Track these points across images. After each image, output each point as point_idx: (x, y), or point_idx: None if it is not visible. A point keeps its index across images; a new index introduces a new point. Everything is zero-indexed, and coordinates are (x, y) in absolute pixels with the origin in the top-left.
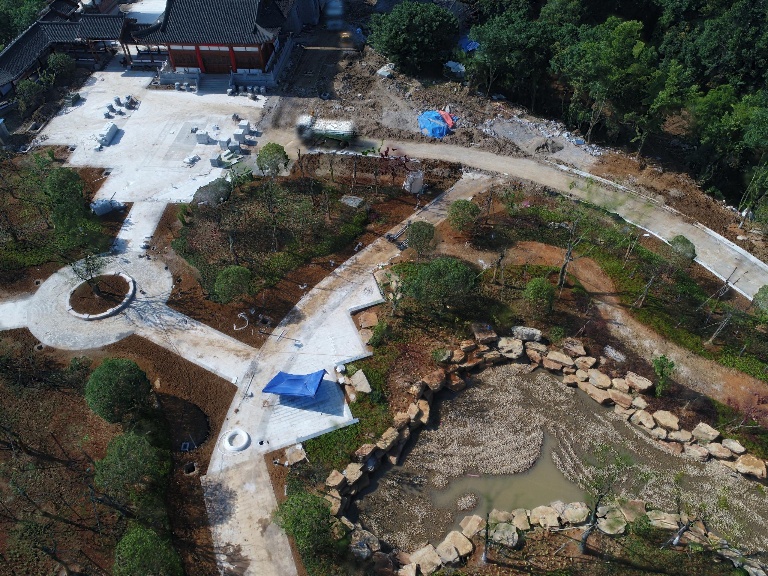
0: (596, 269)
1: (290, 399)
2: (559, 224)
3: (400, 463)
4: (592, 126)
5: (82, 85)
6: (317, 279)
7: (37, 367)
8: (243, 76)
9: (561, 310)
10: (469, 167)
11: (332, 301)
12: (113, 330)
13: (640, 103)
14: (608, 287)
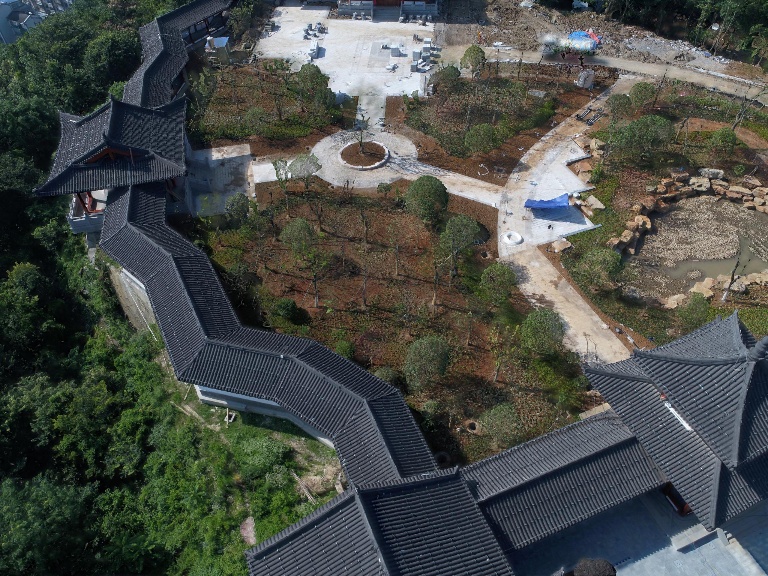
0: (752, 134)
1: (542, 215)
2: (711, 108)
3: (636, 254)
4: (720, 39)
5: (270, 17)
6: (530, 144)
7: (342, 196)
8: (411, 7)
9: (733, 160)
10: (624, 70)
11: (548, 157)
12: (385, 176)
13: (755, 23)
14: (765, 145)
